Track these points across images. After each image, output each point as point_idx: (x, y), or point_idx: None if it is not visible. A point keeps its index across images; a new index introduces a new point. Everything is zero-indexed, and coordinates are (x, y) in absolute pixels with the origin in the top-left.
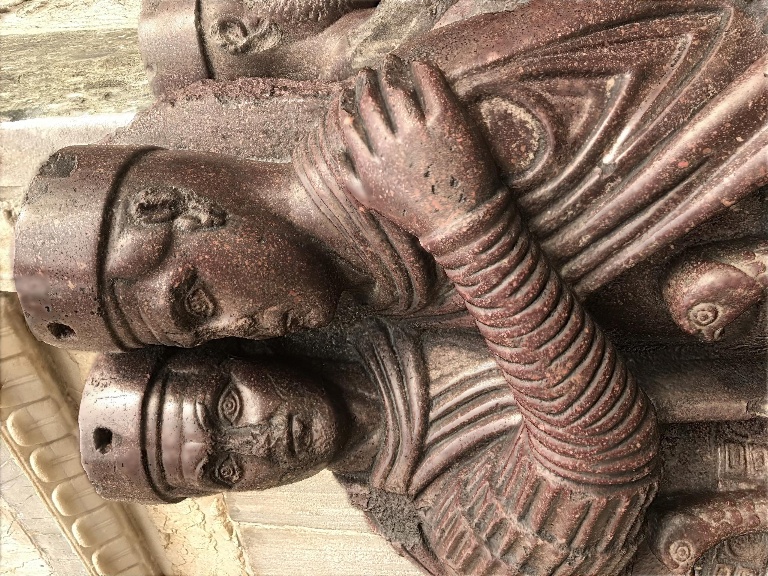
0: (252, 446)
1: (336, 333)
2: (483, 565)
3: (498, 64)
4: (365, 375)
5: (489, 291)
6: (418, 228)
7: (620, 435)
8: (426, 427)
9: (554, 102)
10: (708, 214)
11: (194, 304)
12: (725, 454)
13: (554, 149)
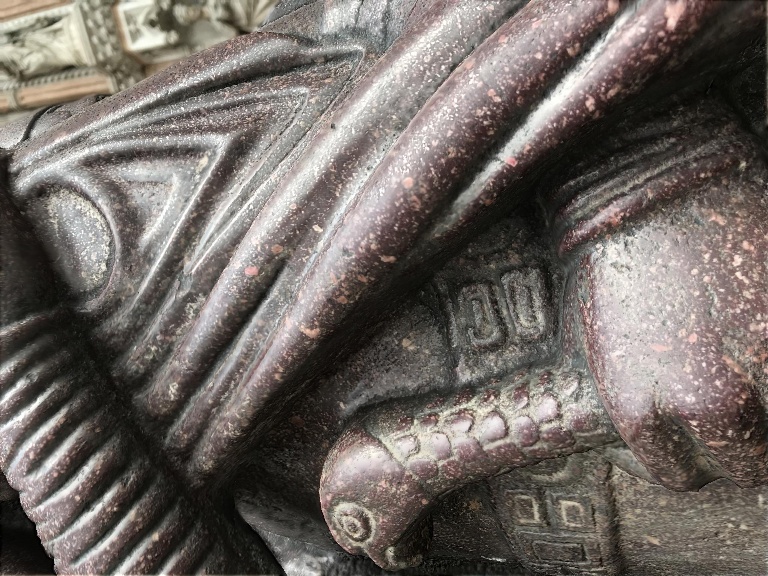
0: None
1: None
2: None
3: (66, 146)
4: None
5: (8, 465)
6: None
7: None
8: None
9: (130, 191)
10: (292, 351)
11: None
12: None
13: (121, 255)
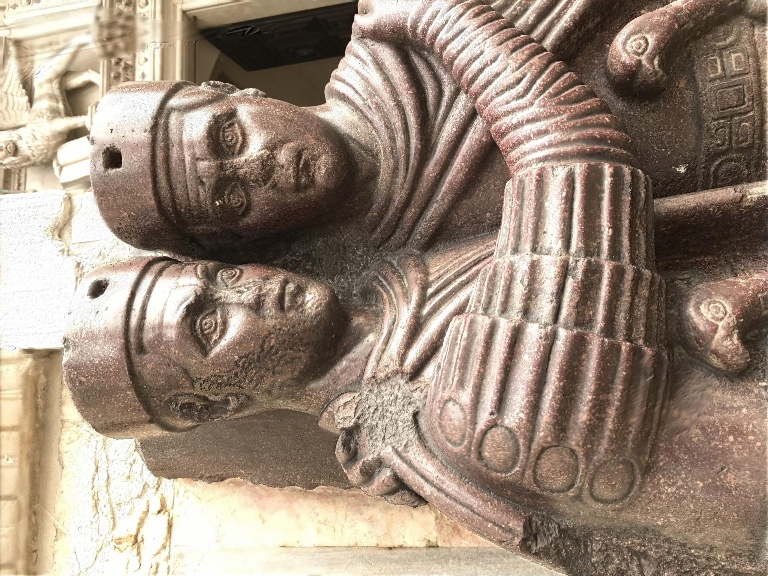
0: (242, 294)
1: (343, 287)
2: (480, 340)
3: None
4: (367, 304)
5: (458, 20)
6: (407, 9)
7: (585, 105)
8: (424, 300)
9: None
10: None
11: (227, 134)
12: (745, 274)
13: None
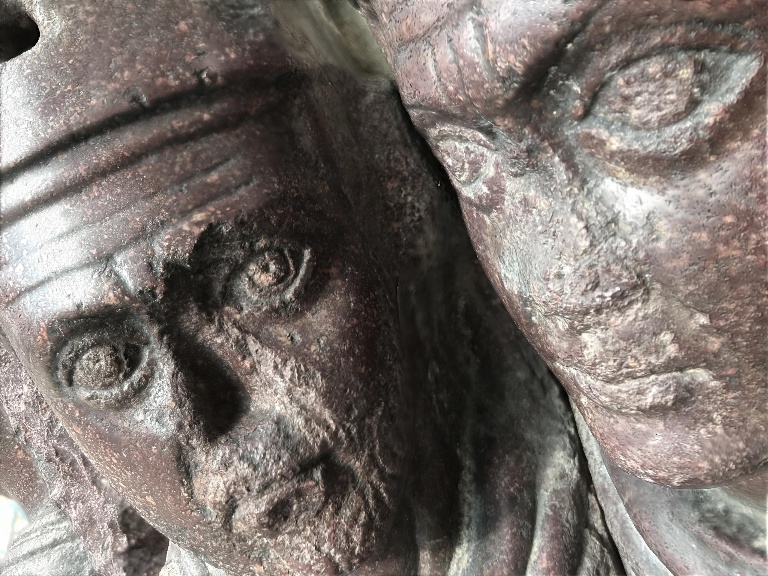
0: None
1: None
2: None
3: None
4: None
5: None
6: None
7: None
8: None
9: None
10: None
11: None
12: None
13: None
